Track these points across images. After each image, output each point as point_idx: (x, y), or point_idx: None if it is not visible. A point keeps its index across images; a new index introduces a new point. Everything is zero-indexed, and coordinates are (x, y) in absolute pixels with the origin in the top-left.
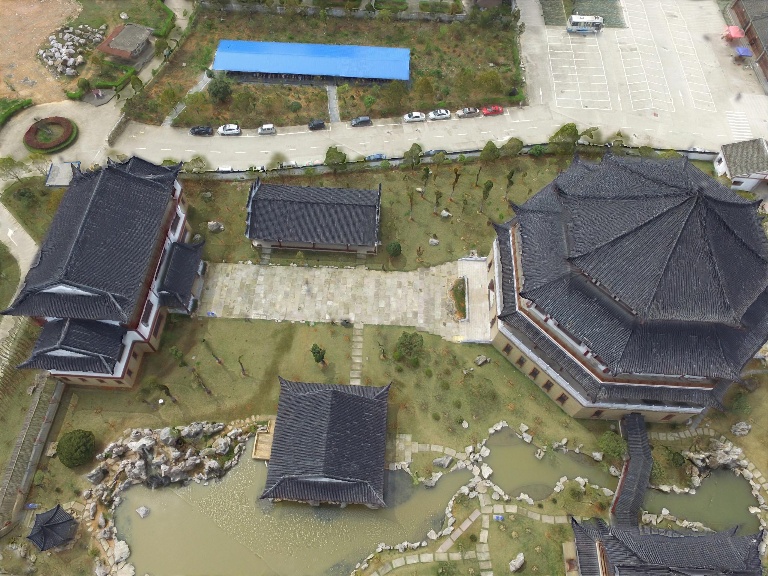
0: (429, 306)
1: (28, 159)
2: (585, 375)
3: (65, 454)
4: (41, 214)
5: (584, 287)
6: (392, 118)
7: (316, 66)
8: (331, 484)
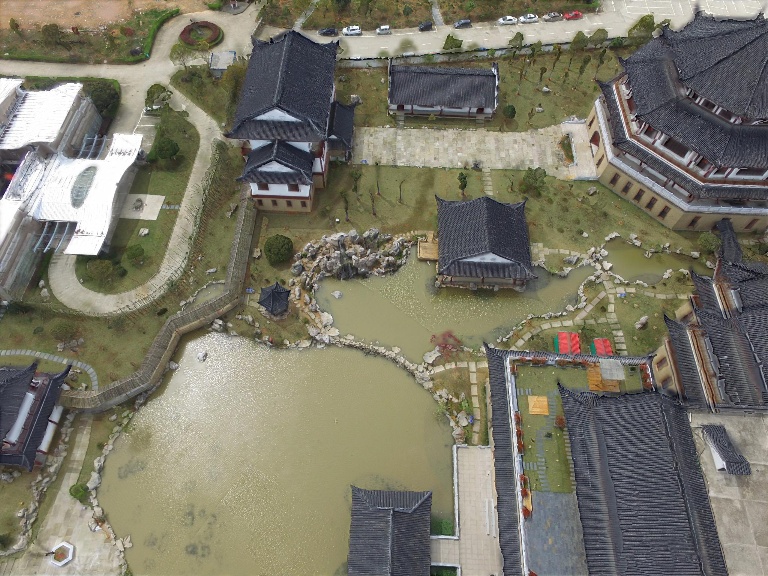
0: (542, 156)
1: None
2: (688, 181)
3: (274, 250)
4: (207, 93)
5: (689, 108)
6: (488, 22)
7: None
8: (491, 264)
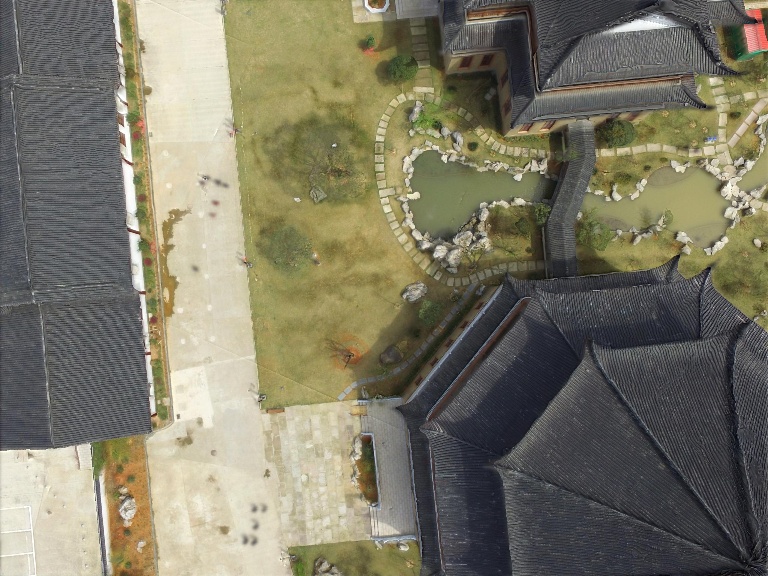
0: None
1: None
2: None
3: None
4: None
5: None
6: None
7: None
8: None
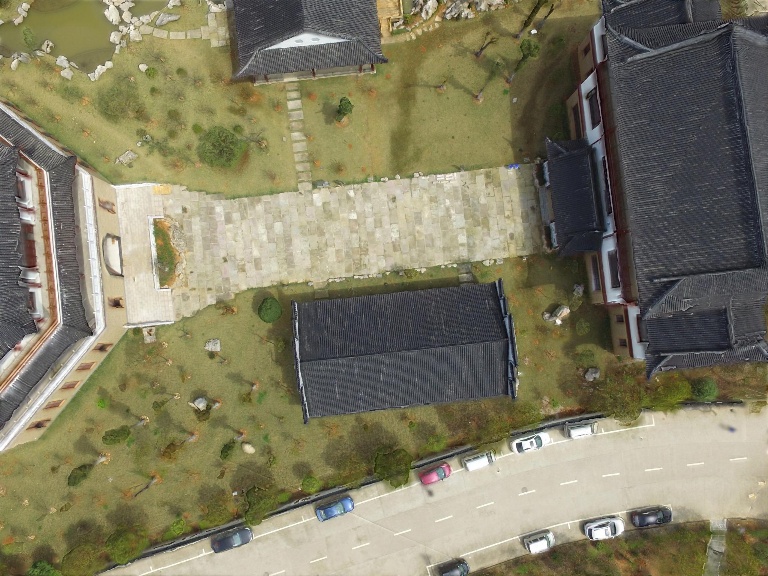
0: (210, 235)
1: None
2: None
3: None
4: None
5: None
6: None
7: None
8: None
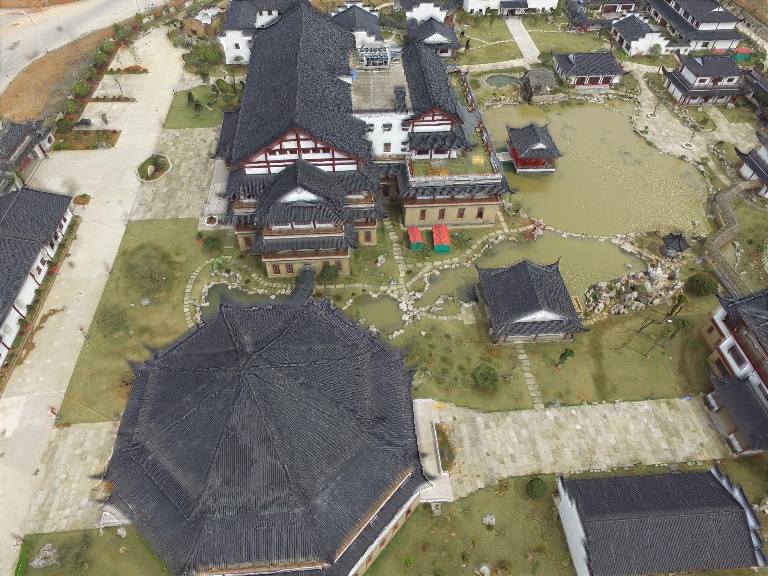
0: (475, 436)
1: None
2: None
3: None
4: None
5: None
6: None
7: None
8: None
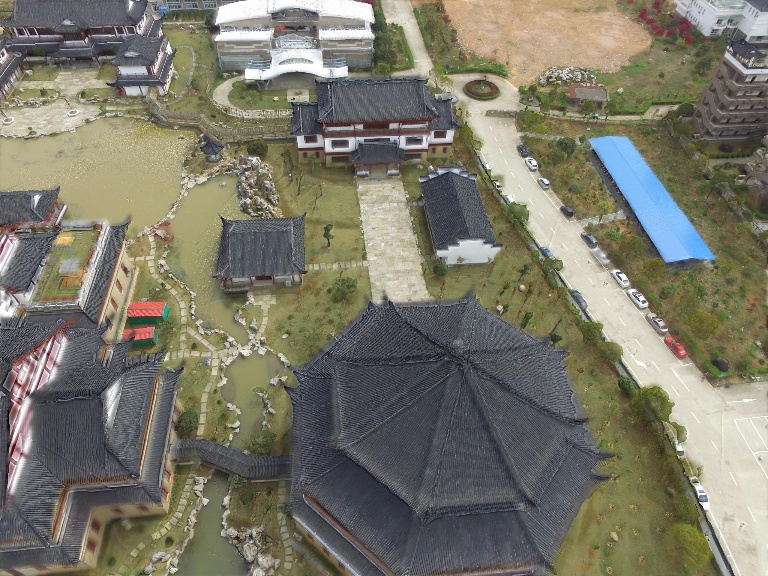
0: None
1: (458, 88)
2: None
3: (252, 142)
4: None
5: None
6: (610, 262)
7: (635, 194)
8: None
